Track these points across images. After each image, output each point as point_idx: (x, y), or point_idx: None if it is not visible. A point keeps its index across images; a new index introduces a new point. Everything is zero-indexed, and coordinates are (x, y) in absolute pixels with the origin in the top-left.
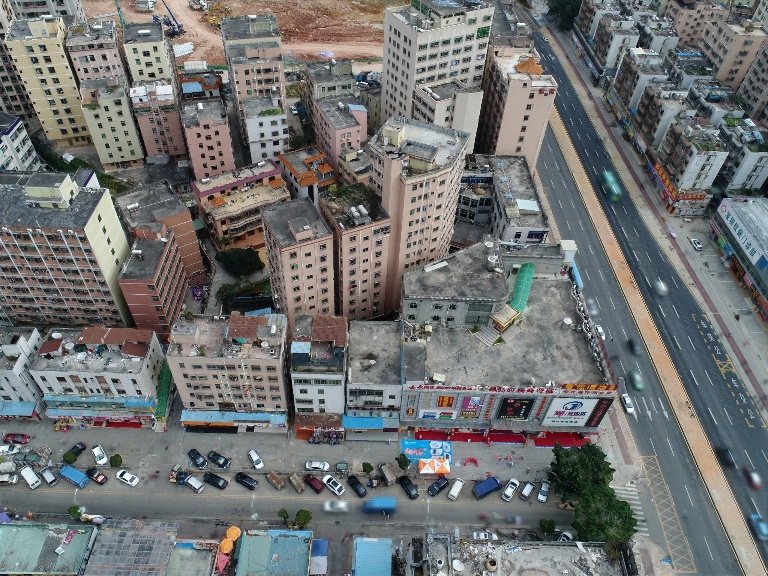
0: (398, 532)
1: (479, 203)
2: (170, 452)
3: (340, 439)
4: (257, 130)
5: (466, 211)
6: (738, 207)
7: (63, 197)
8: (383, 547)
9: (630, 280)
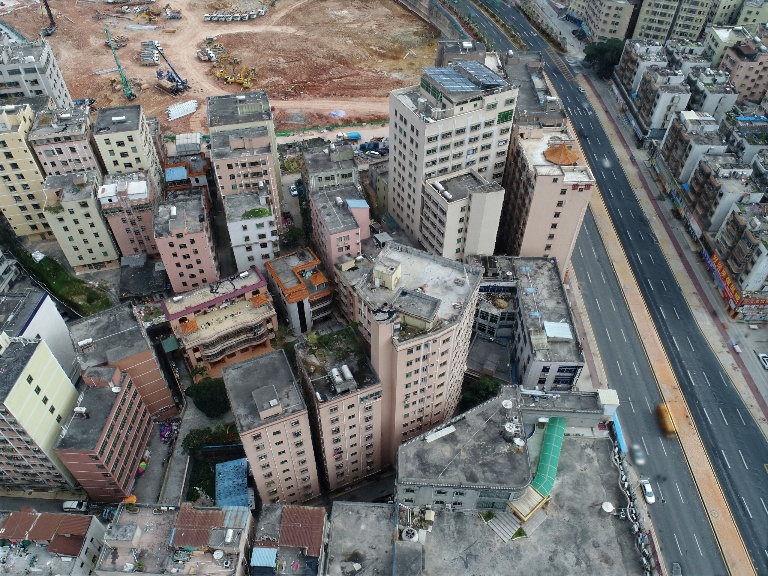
0: None
1: (500, 318)
2: None
3: None
4: (241, 234)
5: (485, 325)
6: None
7: None
8: None
9: (685, 413)
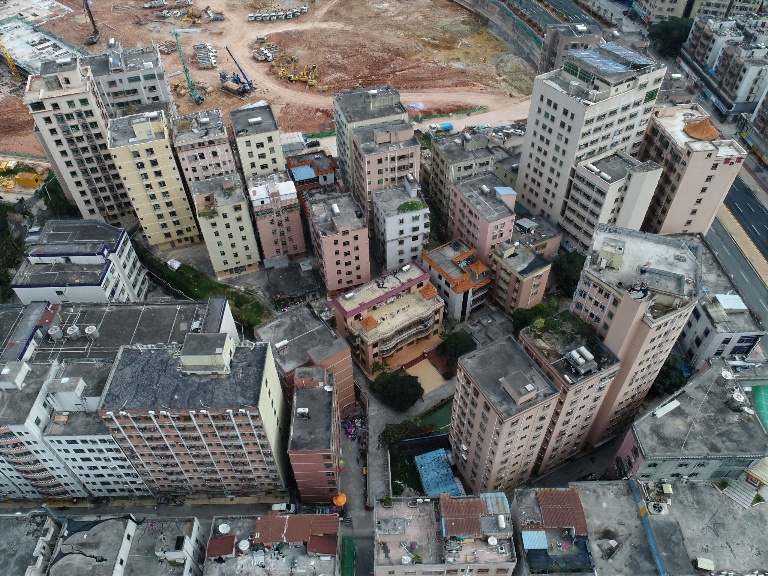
0: None
1: None
2: None
3: None
4: (396, 227)
5: None
6: None
7: (225, 363)
8: None
9: None
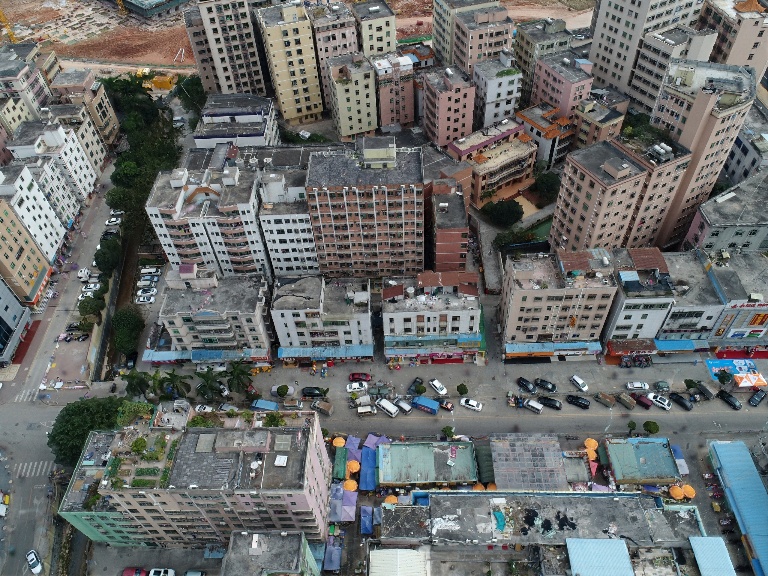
0: (735, 438)
1: None
2: (498, 382)
3: (650, 362)
4: (495, 91)
5: None
6: None
7: (394, 157)
8: (739, 448)
9: None
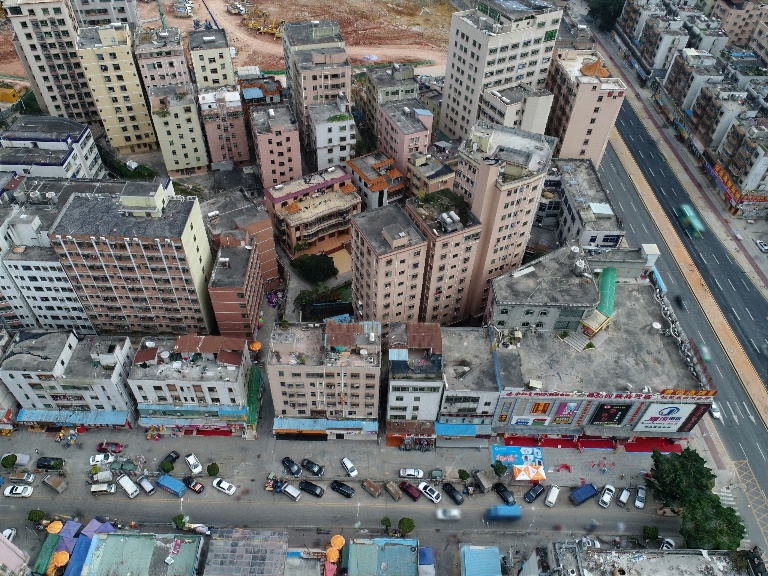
0: (499, 539)
1: (547, 207)
2: (263, 460)
3: (431, 446)
4: (326, 136)
5: None
6: None
7: (157, 206)
8: (491, 555)
9: (700, 283)
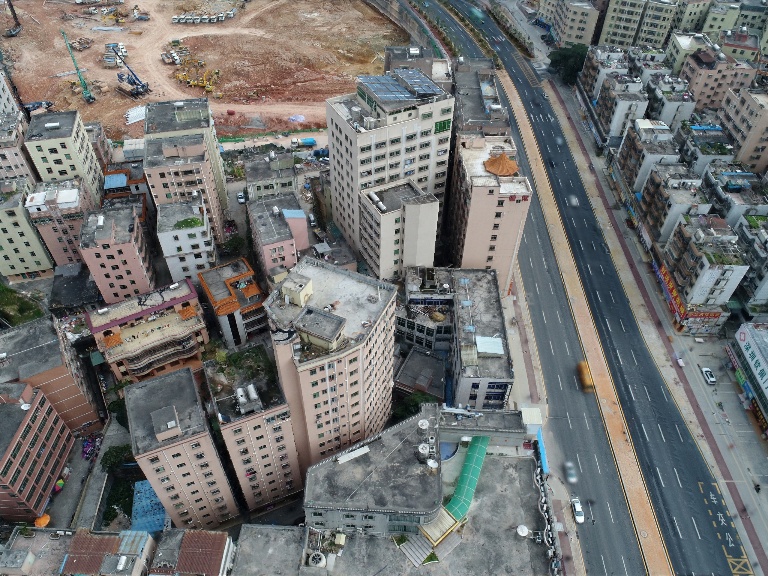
0: None
1: (436, 331)
2: None
3: None
4: (172, 244)
5: (422, 339)
6: (760, 337)
7: None
8: None
9: (622, 430)
